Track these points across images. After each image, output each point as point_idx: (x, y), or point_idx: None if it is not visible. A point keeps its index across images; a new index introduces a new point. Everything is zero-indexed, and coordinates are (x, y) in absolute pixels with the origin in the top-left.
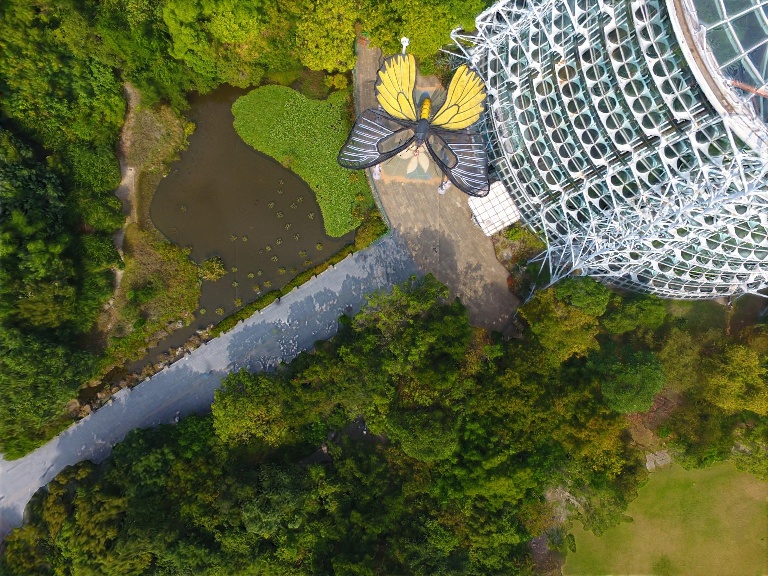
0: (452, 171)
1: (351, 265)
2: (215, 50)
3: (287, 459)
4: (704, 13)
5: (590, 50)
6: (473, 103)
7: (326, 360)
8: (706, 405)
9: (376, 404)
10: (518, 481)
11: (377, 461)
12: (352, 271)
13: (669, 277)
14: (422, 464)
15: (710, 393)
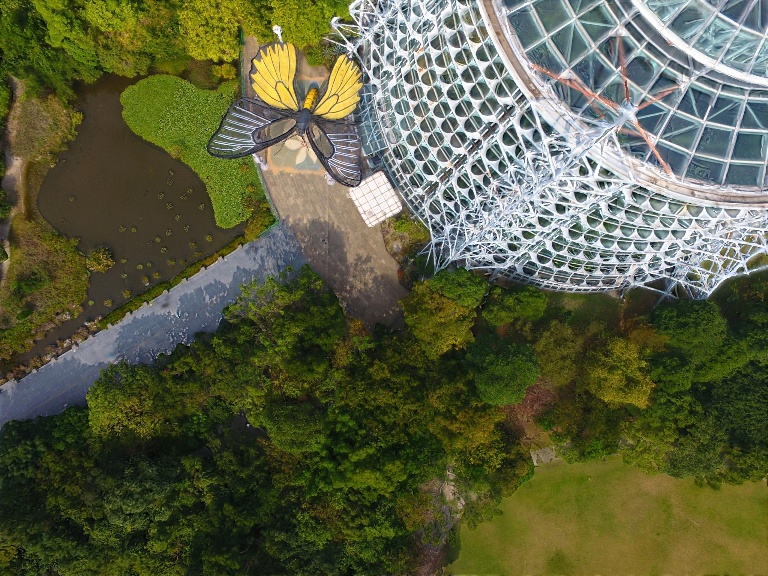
0: (329, 161)
1: (242, 257)
2: (92, 38)
3: (161, 451)
4: None
5: (439, 37)
6: (351, 92)
7: (200, 351)
8: (590, 398)
9: (251, 396)
10: (389, 474)
11: (256, 454)
12: (243, 263)
13: (555, 269)
14: (291, 456)
15: (594, 386)
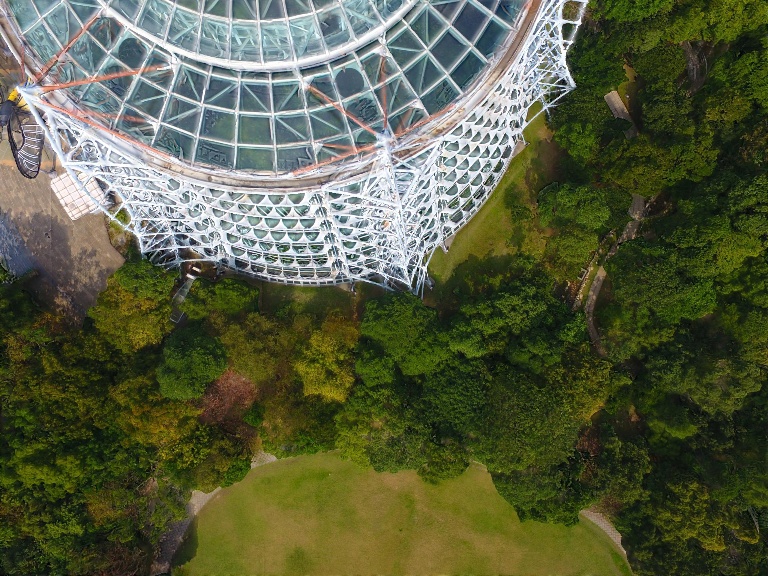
0: (18, 153)
1: None
2: None
3: None
4: None
5: None
6: None
7: None
8: (302, 392)
9: None
10: None
11: None
12: None
13: None
14: None
15: None
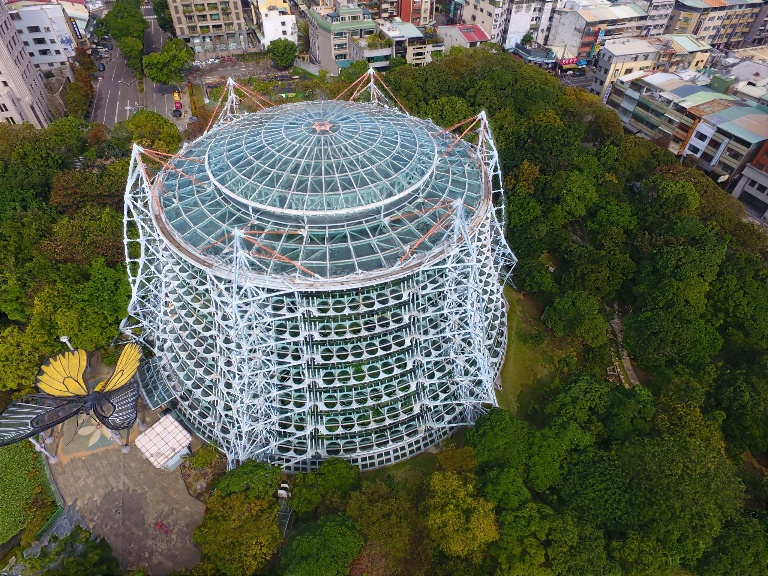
0: (109, 419)
1: None
2: None
3: None
4: (184, 230)
5: None
6: (133, 363)
7: None
8: (447, 560)
9: None
10: None
11: None
12: None
13: None
14: None
15: (444, 543)
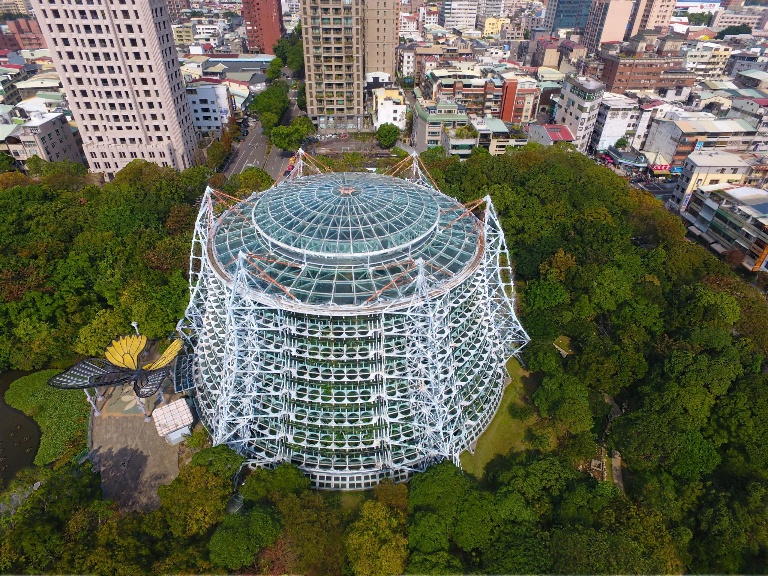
0: (141, 389)
1: None
2: (12, 342)
3: None
4: (223, 252)
5: None
6: (174, 353)
7: None
8: None
9: None
10: None
11: None
12: None
13: (319, 459)
14: None
15: None
